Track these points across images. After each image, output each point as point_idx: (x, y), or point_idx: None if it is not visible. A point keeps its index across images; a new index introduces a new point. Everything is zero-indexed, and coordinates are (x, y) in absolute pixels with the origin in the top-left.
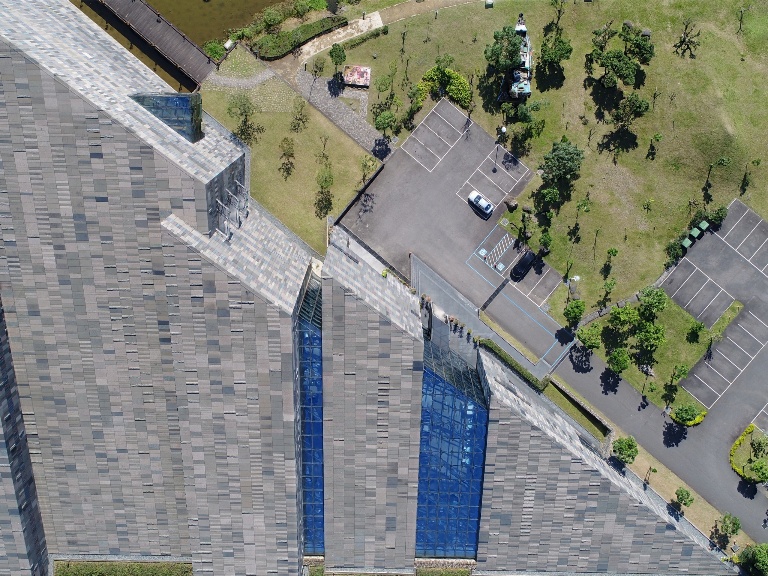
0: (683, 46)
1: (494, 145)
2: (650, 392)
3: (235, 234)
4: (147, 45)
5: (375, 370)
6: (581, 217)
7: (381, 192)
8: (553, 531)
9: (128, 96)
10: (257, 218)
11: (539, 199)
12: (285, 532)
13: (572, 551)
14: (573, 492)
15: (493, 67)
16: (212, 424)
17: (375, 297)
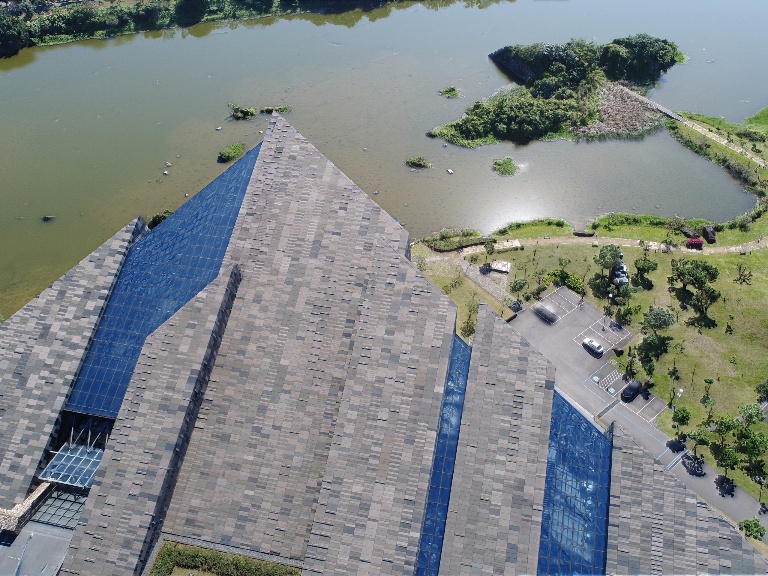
0: (740, 280)
1: (602, 316)
2: (767, 500)
3: None
4: None
5: (512, 383)
6: (678, 363)
7: None
8: None
9: None
10: None
11: (641, 350)
12: (411, 511)
13: None
14: (703, 544)
15: (599, 275)
16: (373, 386)
17: None
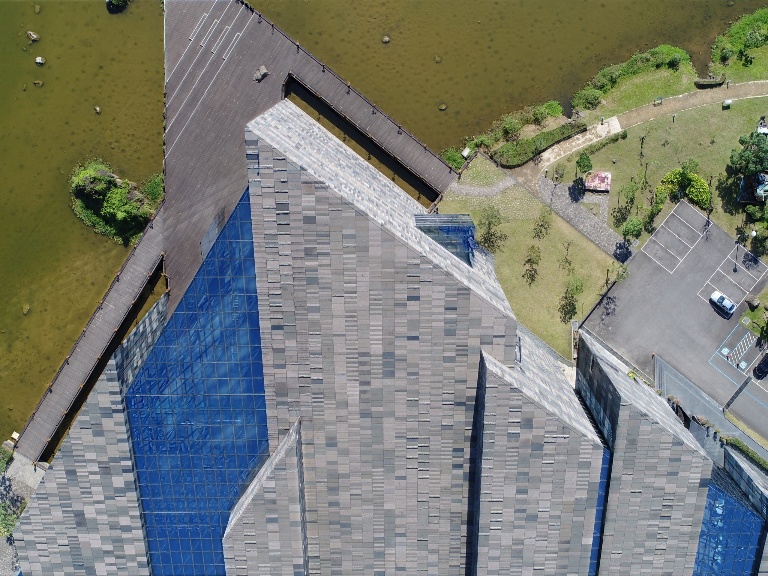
0: None
1: (734, 245)
2: None
3: None
4: (383, 154)
5: (662, 488)
6: None
7: (623, 295)
8: None
9: (415, 226)
10: None
11: None
12: None
13: None
14: None
15: (732, 168)
16: (511, 549)
17: (658, 415)
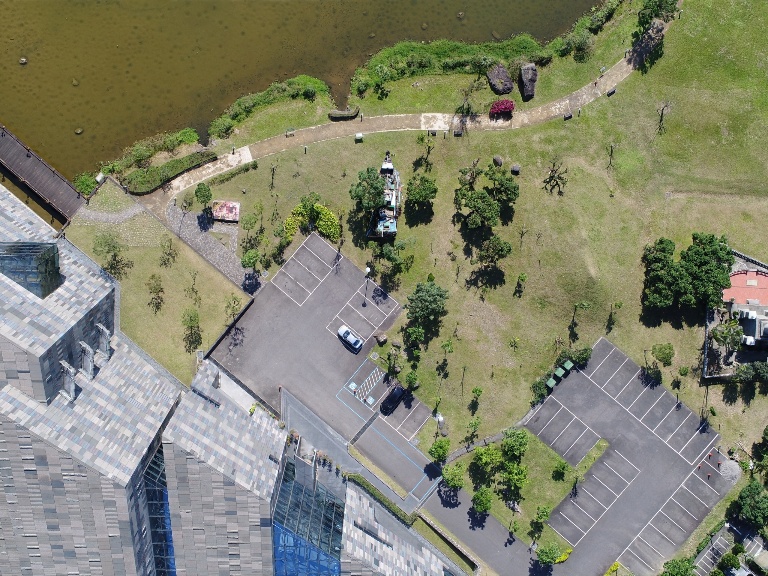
0: (552, 182)
1: (364, 279)
2: None
3: (85, 389)
4: None
5: (223, 526)
6: (449, 353)
7: (251, 326)
8: None
9: None
10: (123, 356)
11: None
12: None
13: None
14: None
15: None
16: None
17: (224, 452)
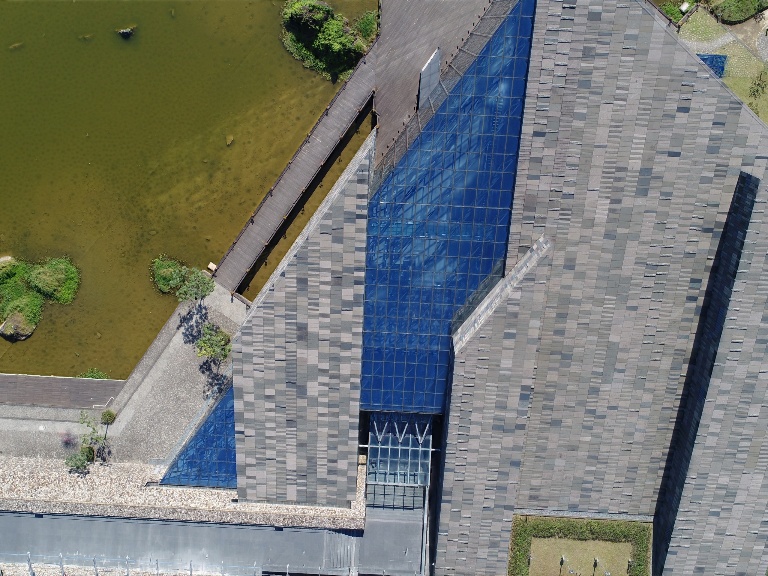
0: None
1: None
2: None
3: None
4: None
5: None
6: None
7: None
8: None
9: None
10: None
11: None
12: None
13: None
14: None
15: None
16: (743, 383)
17: None
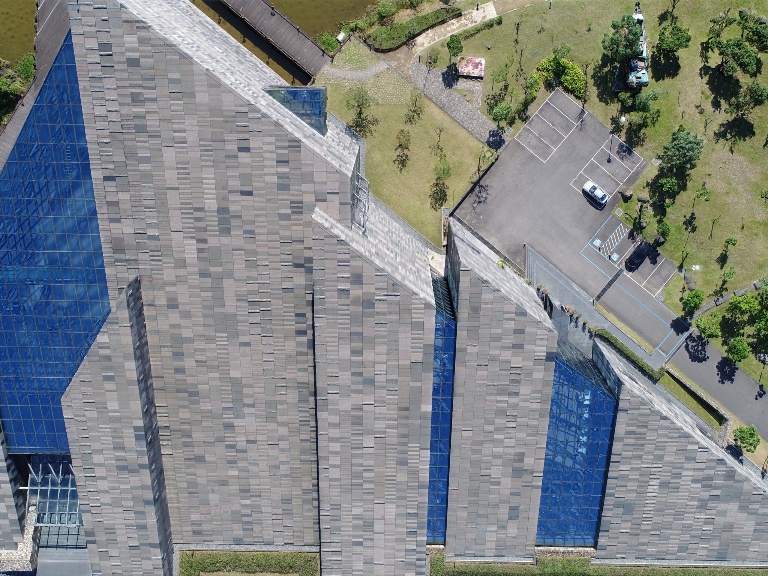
0: None
1: (608, 135)
2: (767, 381)
3: (366, 226)
4: (259, 38)
5: (508, 361)
6: (697, 206)
7: (495, 183)
8: (675, 519)
9: (262, 90)
10: (375, 210)
11: (654, 189)
12: (415, 521)
13: (692, 539)
14: (697, 481)
15: (608, 57)
16: (350, 415)
17: (507, 288)
